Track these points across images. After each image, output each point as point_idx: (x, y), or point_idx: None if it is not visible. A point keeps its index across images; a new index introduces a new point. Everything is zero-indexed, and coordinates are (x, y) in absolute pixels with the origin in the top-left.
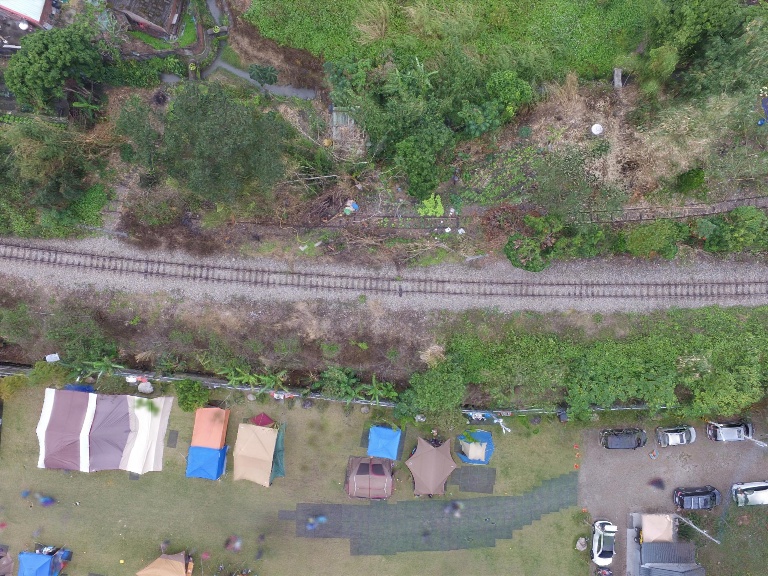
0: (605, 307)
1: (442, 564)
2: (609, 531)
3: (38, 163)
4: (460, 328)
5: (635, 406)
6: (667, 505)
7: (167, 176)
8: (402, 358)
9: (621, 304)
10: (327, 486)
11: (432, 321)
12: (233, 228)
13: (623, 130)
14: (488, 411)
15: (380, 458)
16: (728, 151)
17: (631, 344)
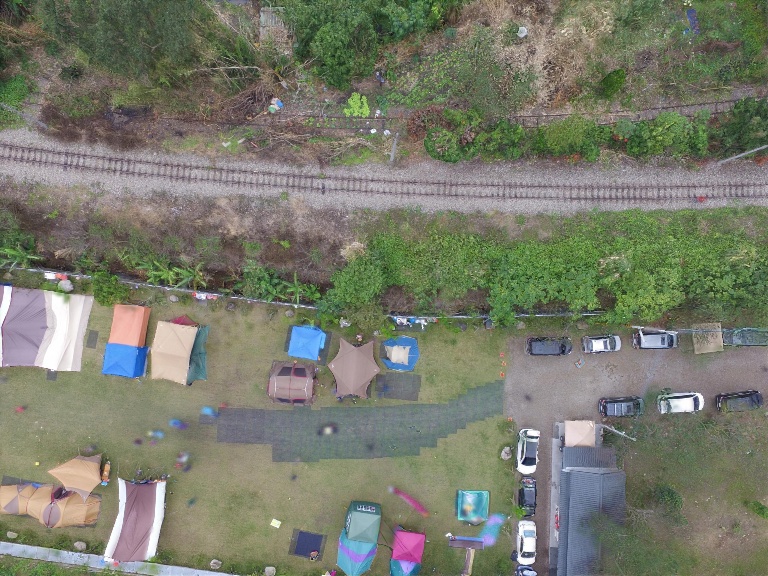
0: (528, 208)
1: (366, 472)
2: (532, 436)
3: None
4: (383, 227)
5: (560, 313)
6: (593, 415)
7: (91, 71)
8: (325, 258)
9: (544, 206)
10: (250, 390)
11: (355, 220)
12: (156, 124)
13: (549, 36)
14: None
15: (304, 363)
16: (653, 59)
17: (553, 245)
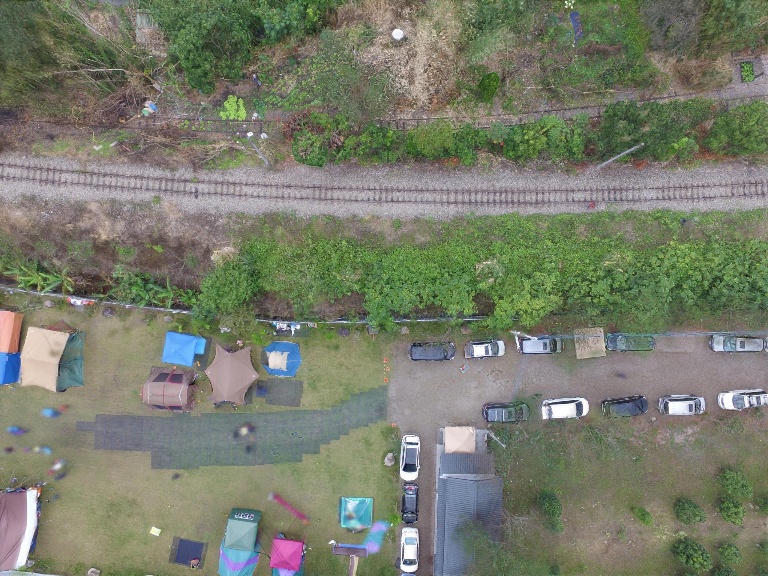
0: (404, 213)
1: (247, 479)
2: (411, 443)
3: None
4: (258, 232)
5: (442, 318)
6: (478, 421)
7: None
8: (200, 263)
9: (420, 210)
10: (128, 397)
11: (229, 224)
12: (27, 127)
13: (430, 39)
14: (295, 322)
15: (184, 369)
16: (534, 62)
17: (429, 250)
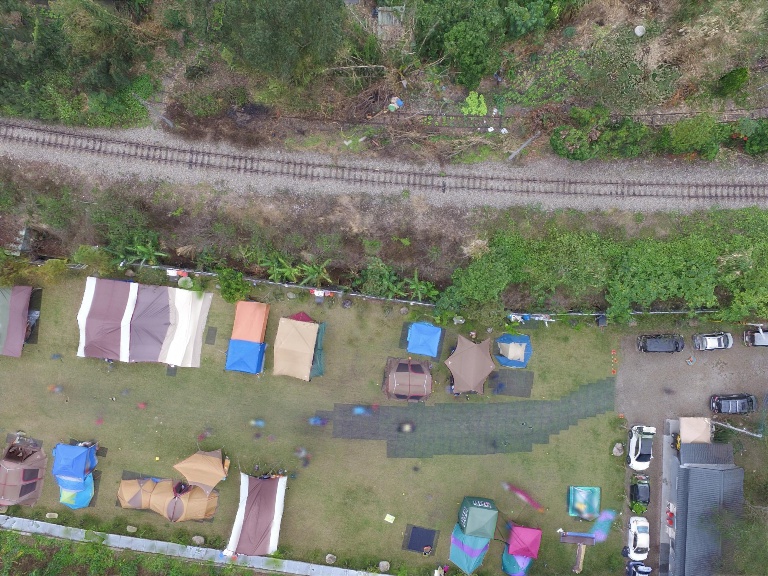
0: (646, 206)
1: (479, 468)
2: (647, 433)
3: (92, 35)
4: (502, 225)
5: (673, 310)
6: (703, 412)
7: (212, 70)
8: (444, 255)
9: (662, 204)
10: (365, 387)
11: (475, 218)
12: (278, 122)
13: (664, 35)
14: None
15: (418, 360)
16: (767, 58)
17: (672, 243)
